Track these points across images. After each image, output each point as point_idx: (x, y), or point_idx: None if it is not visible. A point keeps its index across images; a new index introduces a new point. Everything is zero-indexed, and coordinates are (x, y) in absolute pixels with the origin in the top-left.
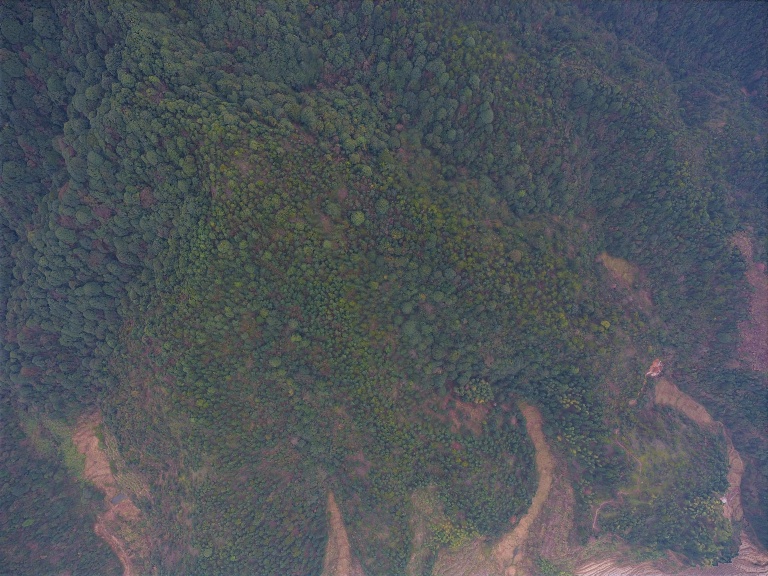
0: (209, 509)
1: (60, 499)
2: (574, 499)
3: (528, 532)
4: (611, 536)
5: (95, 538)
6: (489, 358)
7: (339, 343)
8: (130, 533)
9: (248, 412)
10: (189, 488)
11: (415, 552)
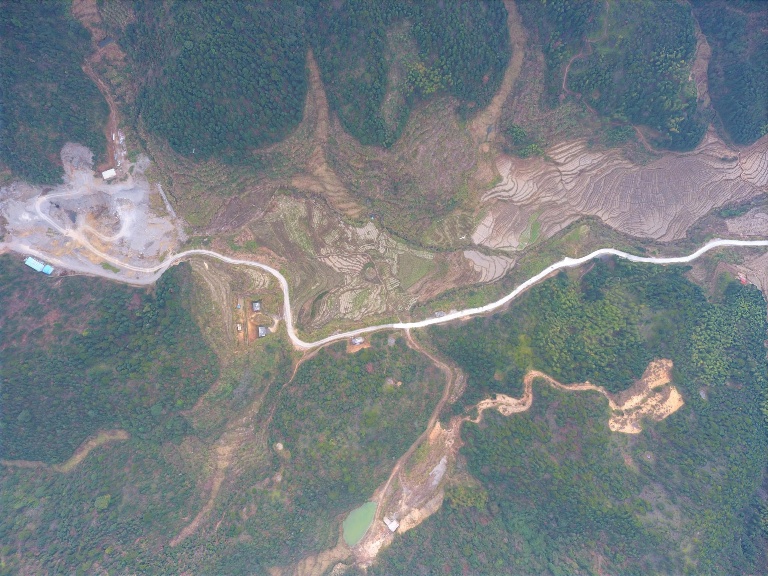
0: None
1: (48, 23)
2: (545, 64)
3: (501, 110)
4: (581, 99)
5: (82, 71)
6: None
7: None
8: (116, 76)
9: None
10: None
11: (390, 89)
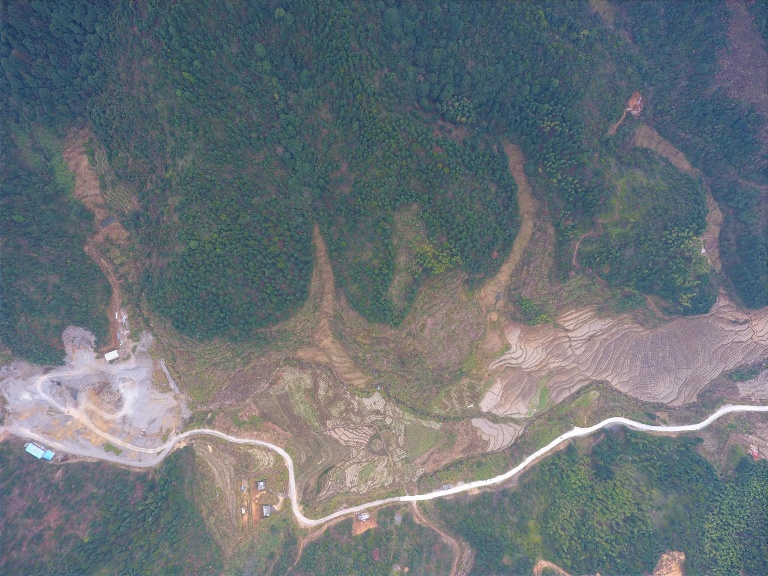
0: (195, 197)
1: (50, 210)
2: (555, 238)
3: (510, 278)
4: (591, 273)
5: (84, 254)
6: (470, 62)
7: (322, 13)
8: (119, 256)
9: (233, 102)
10: (176, 180)
11: (398, 272)
